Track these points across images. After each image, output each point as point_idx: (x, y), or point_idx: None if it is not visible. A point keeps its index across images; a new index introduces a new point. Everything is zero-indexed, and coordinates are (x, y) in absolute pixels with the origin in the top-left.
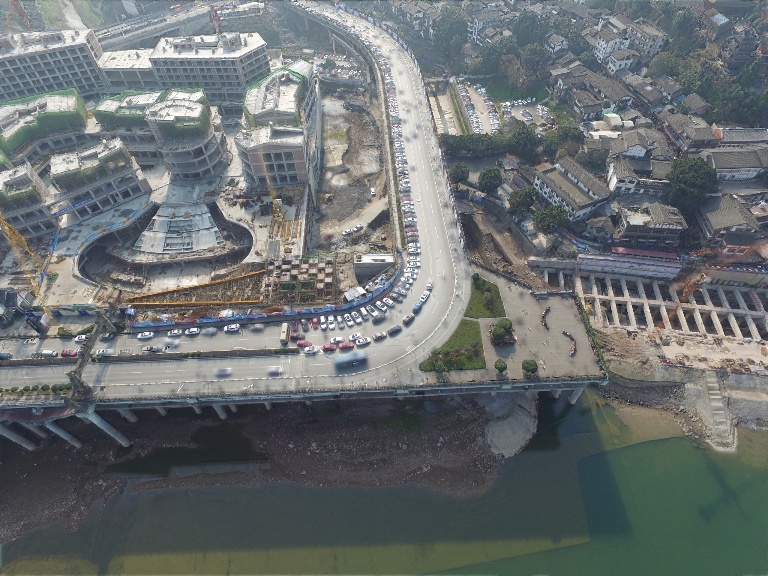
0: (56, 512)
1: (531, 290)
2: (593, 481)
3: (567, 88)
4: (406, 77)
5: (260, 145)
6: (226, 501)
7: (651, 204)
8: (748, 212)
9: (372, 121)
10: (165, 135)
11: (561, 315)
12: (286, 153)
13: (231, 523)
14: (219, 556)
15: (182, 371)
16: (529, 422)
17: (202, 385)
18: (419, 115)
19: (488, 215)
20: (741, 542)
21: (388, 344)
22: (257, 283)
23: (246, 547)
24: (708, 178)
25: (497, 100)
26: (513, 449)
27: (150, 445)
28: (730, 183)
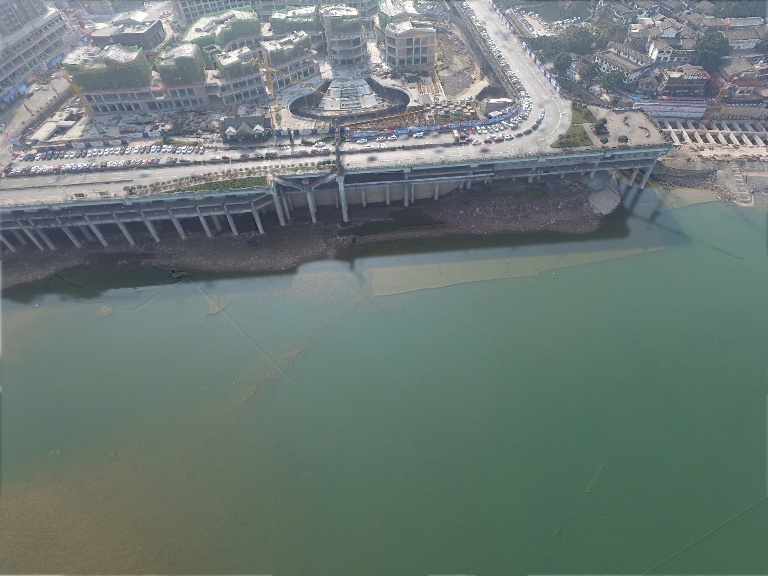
0: (316, 251)
1: (613, 109)
2: (663, 223)
3: (606, 5)
4: (479, 4)
5: (407, 31)
6: (425, 243)
7: (684, 65)
8: (752, 66)
9: (456, 38)
10: (334, 29)
11: (635, 120)
12: (423, 38)
13: (433, 252)
14: (432, 266)
15: (395, 156)
16: (615, 196)
17: (413, 160)
18: (498, 26)
19: (561, 89)
20: (761, 243)
21: (526, 138)
22: (421, 117)
23: (447, 261)
24: (723, 44)
25: (549, 21)
26: (608, 210)
27: (363, 220)
28: (737, 52)
